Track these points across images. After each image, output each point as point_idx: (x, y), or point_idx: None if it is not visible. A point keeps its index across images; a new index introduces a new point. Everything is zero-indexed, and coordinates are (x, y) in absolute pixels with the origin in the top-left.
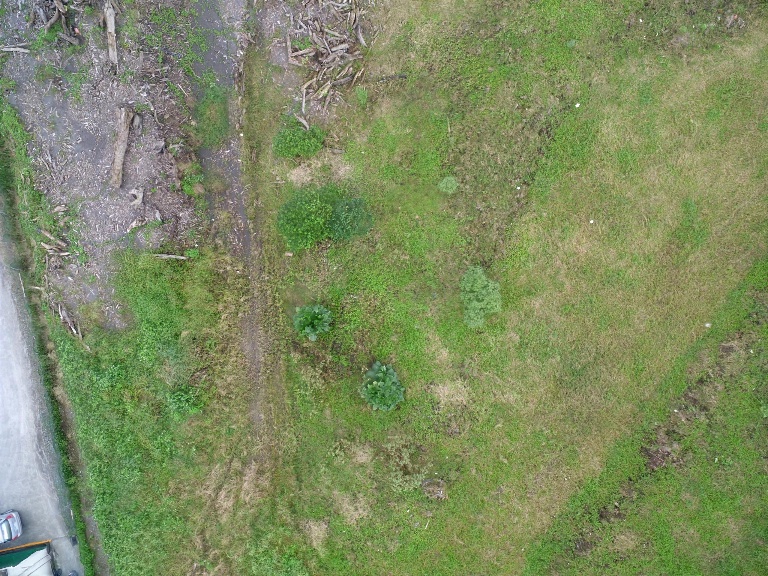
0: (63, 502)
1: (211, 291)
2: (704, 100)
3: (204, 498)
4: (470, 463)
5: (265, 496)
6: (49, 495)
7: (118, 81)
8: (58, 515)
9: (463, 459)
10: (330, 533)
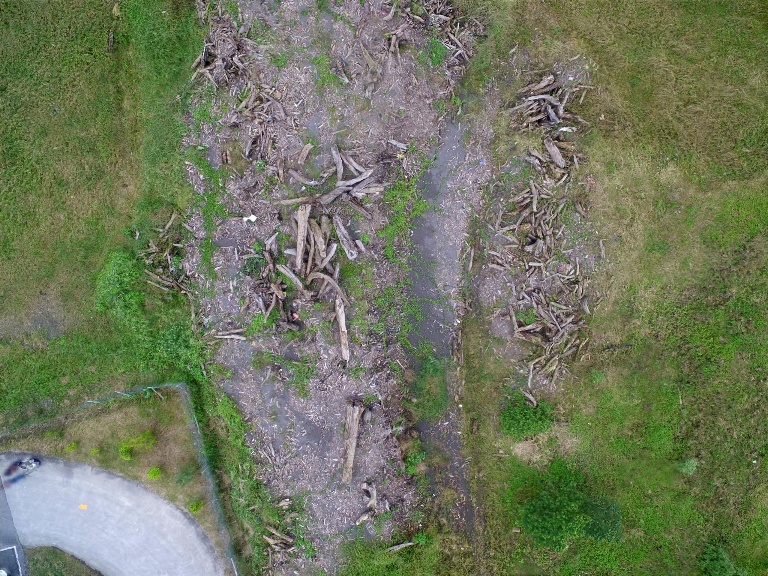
0: None
1: (438, 573)
2: None
3: None
4: None
5: None
6: None
7: (348, 375)
8: None
9: None
10: None
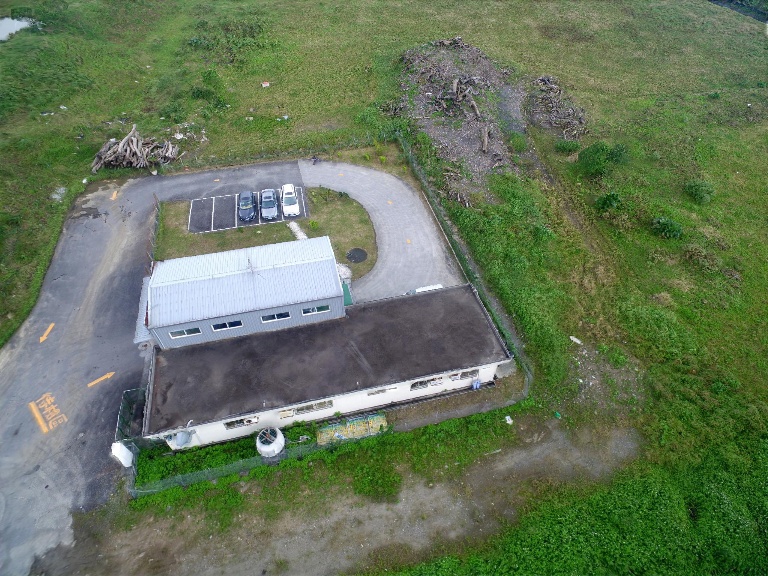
0: None
1: None
2: (760, 139)
3: (573, 283)
4: (745, 263)
5: (616, 281)
6: None
7: None
8: None
9: (739, 261)
10: (674, 298)
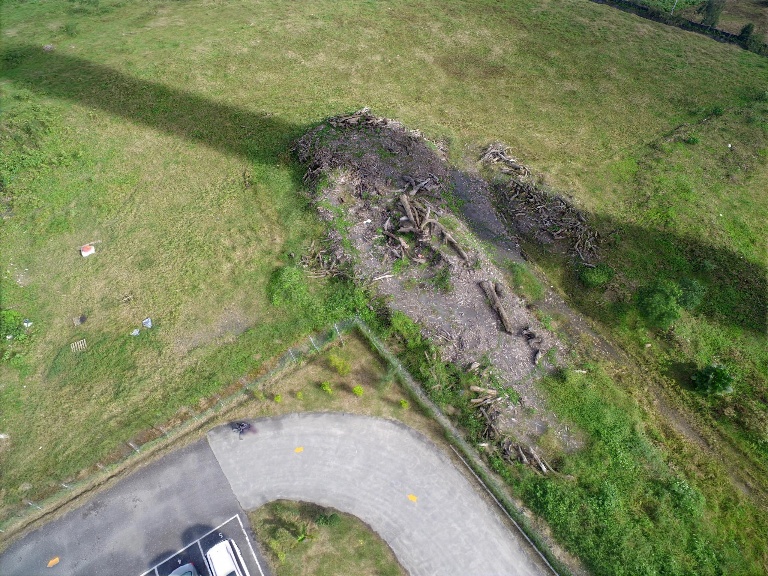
0: None
1: None
2: None
3: None
4: None
5: None
6: None
7: (473, 270)
8: None
9: None
10: None
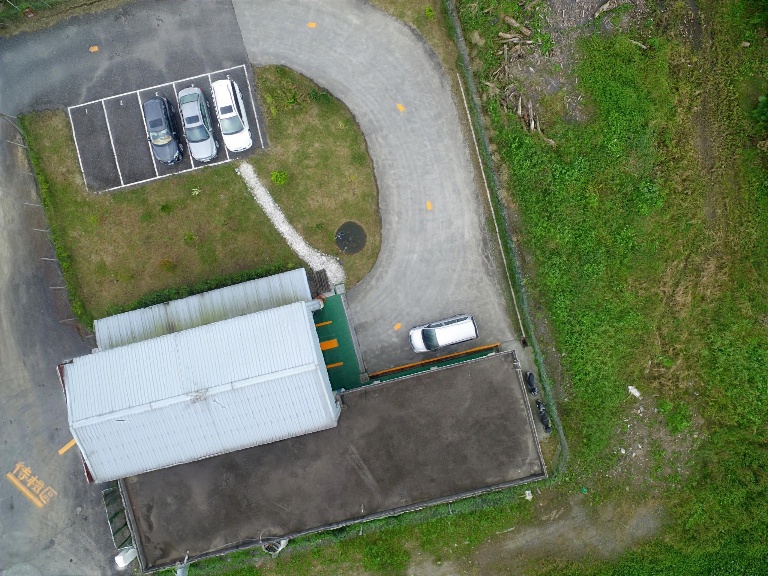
0: (510, 306)
1: None
2: None
3: (661, 295)
4: None
5: (724, 291)
6: (496, 299)
7: None
8: (506, 319)
9: None
10: None
